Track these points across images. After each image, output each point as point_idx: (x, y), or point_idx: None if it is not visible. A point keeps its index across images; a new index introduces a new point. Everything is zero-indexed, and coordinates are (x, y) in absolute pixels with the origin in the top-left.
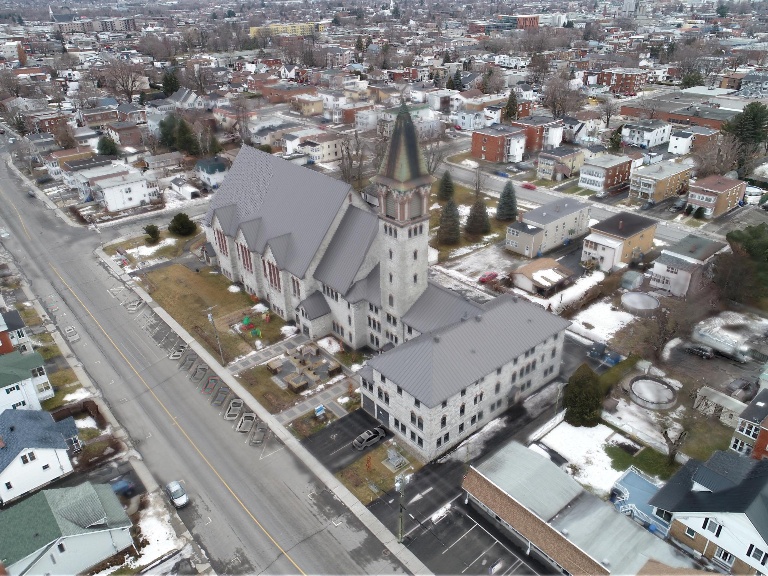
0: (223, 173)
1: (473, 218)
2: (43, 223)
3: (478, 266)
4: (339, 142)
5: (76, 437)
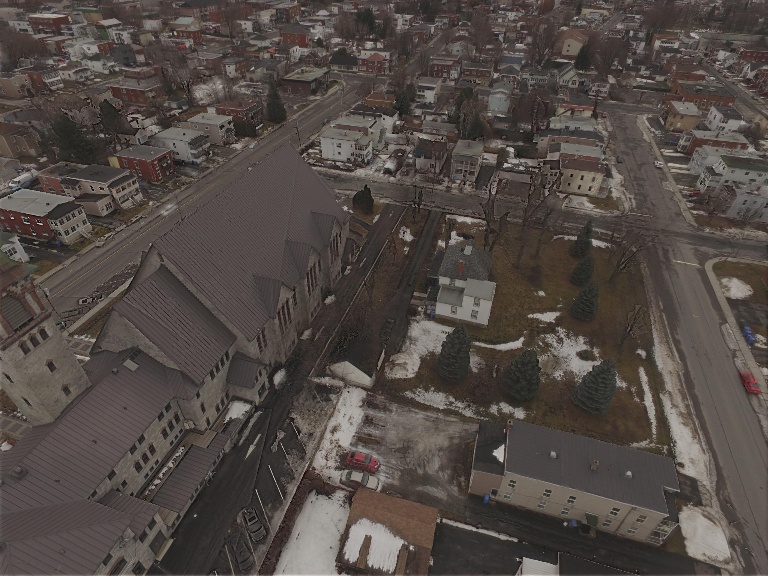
0: (429, 160)
1: (508, 369)
2: None
3: (394, 434)
4: (590, 175)
5: None
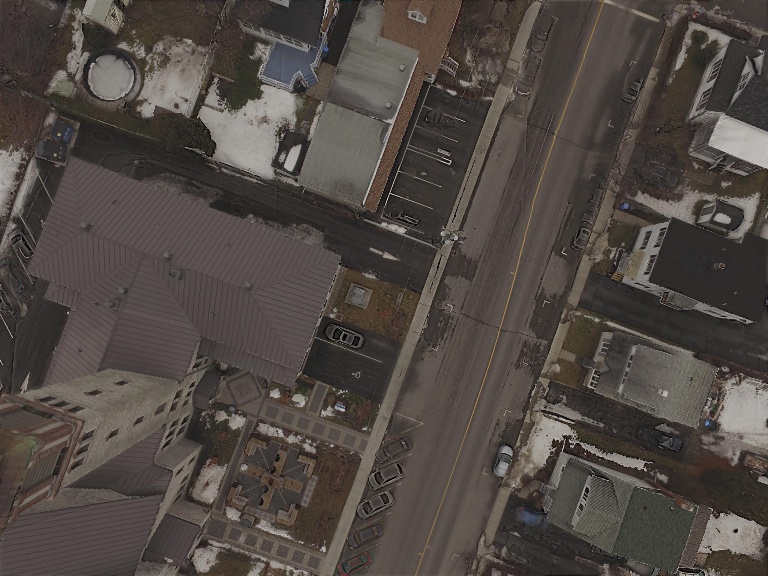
0: None
1: None
2: None
3: None
4: None
5: None
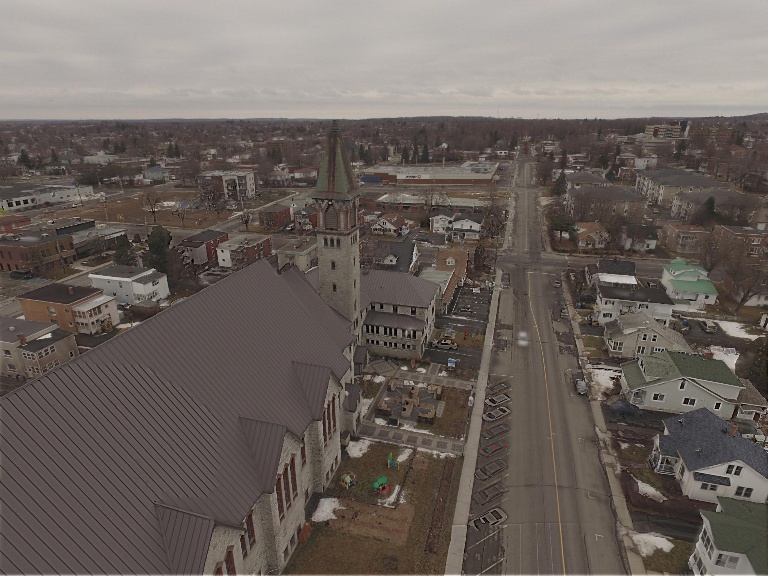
0: None
1: None
2: None
3: None
4: None
5: None
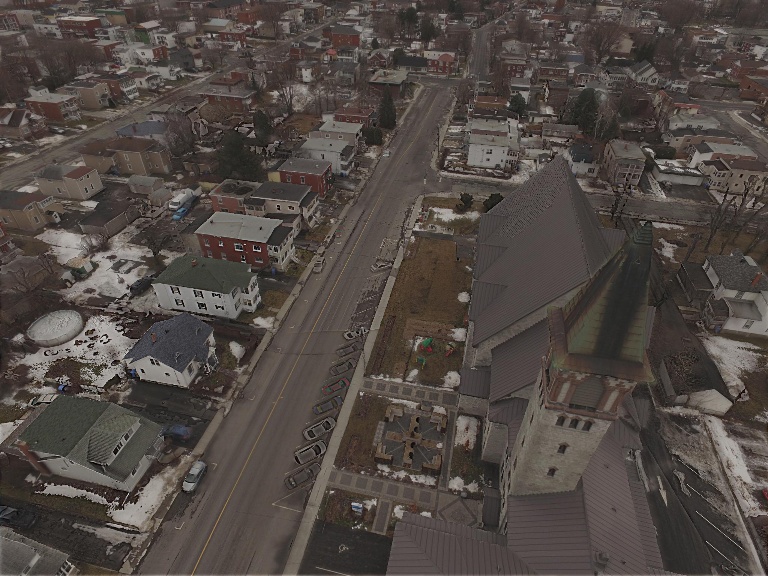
0: (589, 165)
1: None
2: (418, 155)
3: None
4: (761, 175)
5: (206, 363)
